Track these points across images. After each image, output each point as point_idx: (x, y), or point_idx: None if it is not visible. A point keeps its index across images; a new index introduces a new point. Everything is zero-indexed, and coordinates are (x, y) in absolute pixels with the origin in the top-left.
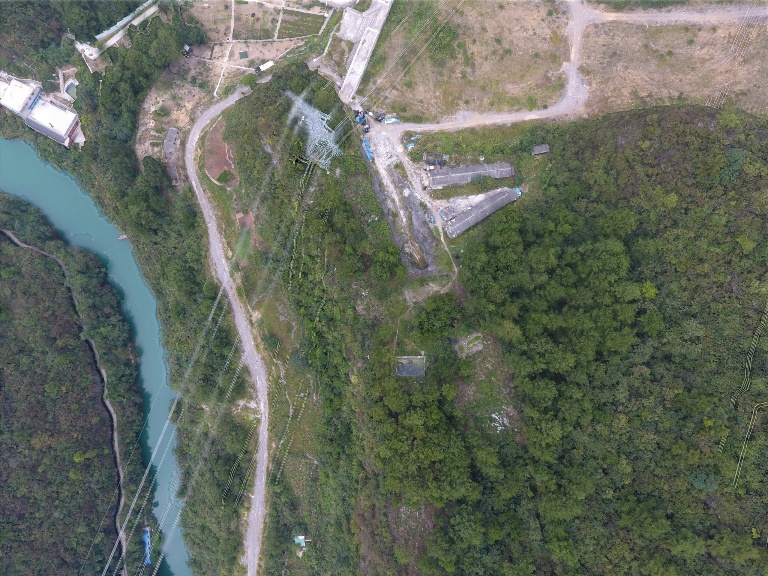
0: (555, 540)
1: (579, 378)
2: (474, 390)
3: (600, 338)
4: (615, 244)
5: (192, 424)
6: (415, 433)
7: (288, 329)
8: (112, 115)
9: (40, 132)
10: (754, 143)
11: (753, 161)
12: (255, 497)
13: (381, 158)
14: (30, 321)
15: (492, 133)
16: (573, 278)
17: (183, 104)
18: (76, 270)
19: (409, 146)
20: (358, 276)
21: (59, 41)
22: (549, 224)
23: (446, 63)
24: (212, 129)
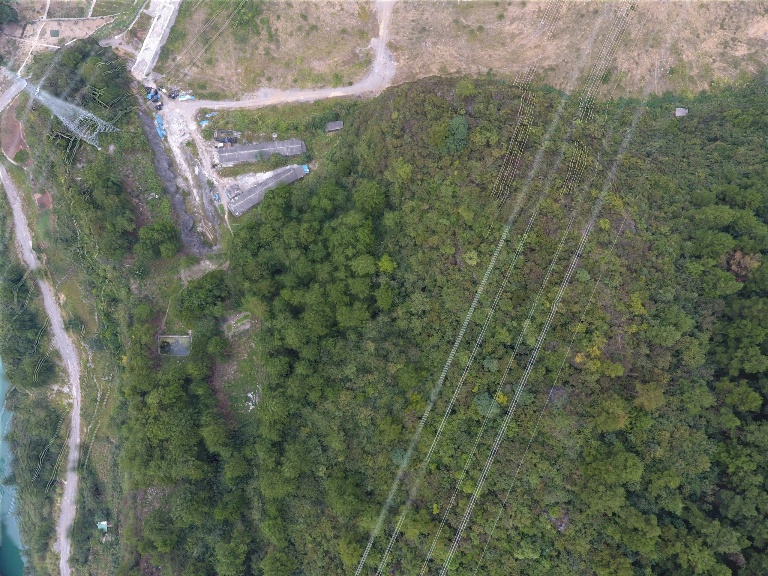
0: (267, 519)
1: (311, 354)
2: (234, 369)
3: (331, 313)
4: (354, 217)
5: (15, 410)
6: (150, 412)
7: (91, 311)
8: None
9: None
10: (492, 112)
11: (484, 130)
12: (68, 483)
13: (174, 136)
14: None
15: (292, 110)
16: (321, 253)
17: None
18: None
19: (203, 123)
20: (122, 254)
21: None
22: (312, 199)
23: (249, 39)
24: (9, 108)
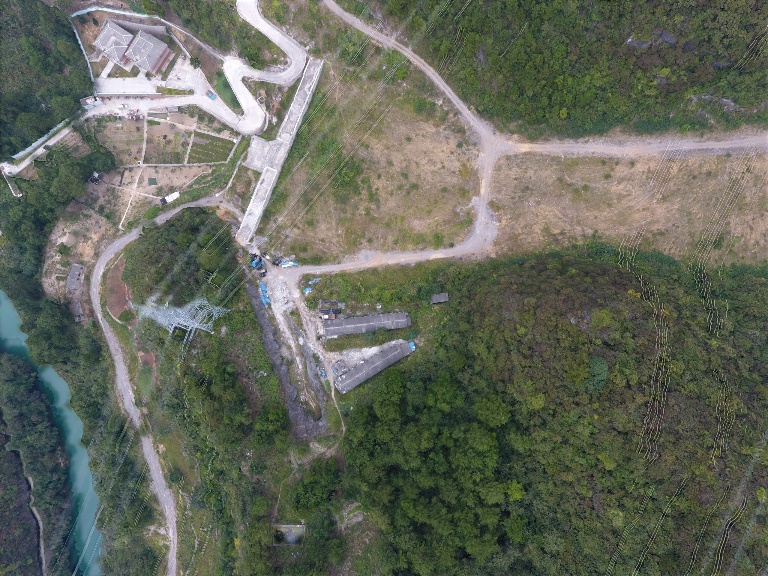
0: None
1: None
2: (349, 566)
3: (460, 543)
4: (482, 441)
5: (110, 540)
6: None
7: (191, 465)
8: (19, 248)
9: None
10: (629, 342)
11: (623, 367)
12: None
13: (278, 303)
14: None
15: (394, 275)
16: (444, 467)
17: (89, 236)
18: (3, 380)
19: (306, 291)
20: (237, 444)
21: None
22: (429, 399)
23: (349, 200)
24: (113, 267)
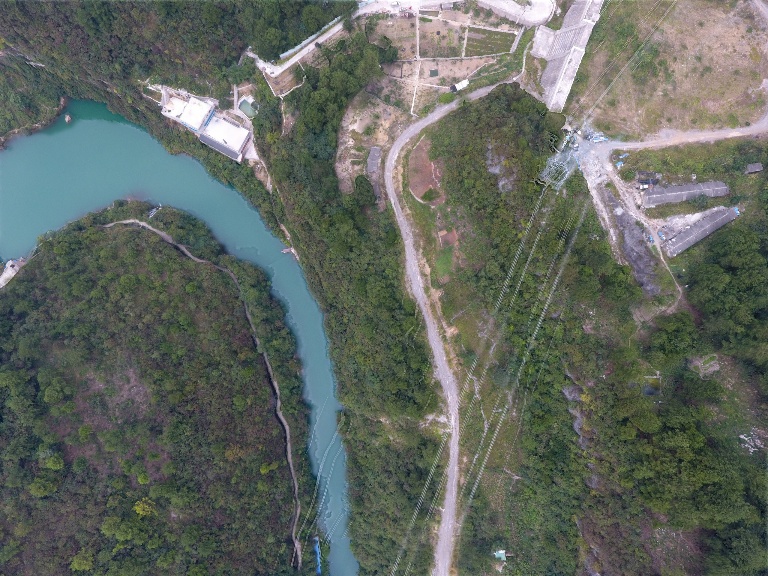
0: None
1: None
2: (717, 411)
3: None
4: None
5: (372, 437)
6: (681, 455)
7: (487, 345)
8: (313, 134)
9: (213, 148)
10: None
11: None
12: (445, 510)
13: (591, 177)
14: (214, 335)
15: (698, 151)
16: None
17: (380, 123)
18: (249, 284)
19: (618, 165)
20: (595, 296)
21: (238, 59)
22: None
23: (648, 81)
24: (416, 148)
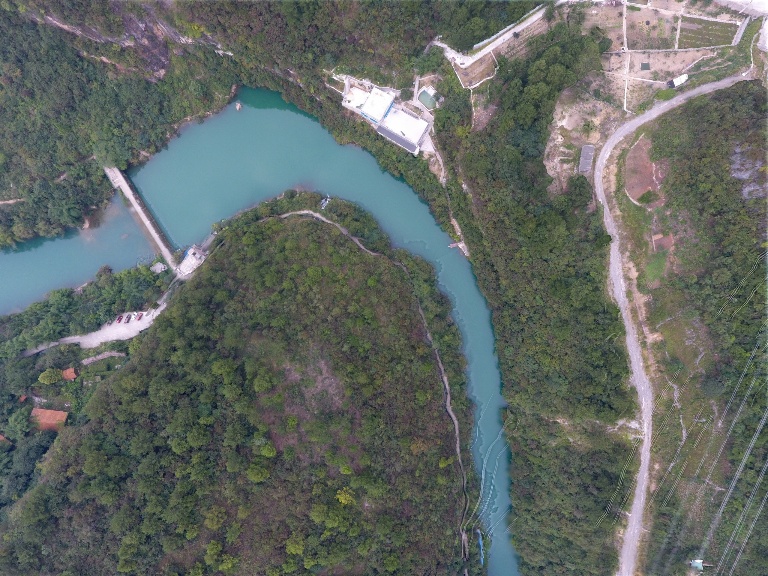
0: None
1: None
2: None
3: None
4: None
5: (551, 437)
6: None
7: (695, 354)
8: (521, 130)
9: (390, 140)
10: None
11: None
12: (632, 515)
13: None
14: (394, 329)
15: None
16: None
17: (590, 119)
18: (423, 279)
19: None
20: None
21: (424, 49)
22: None
23: None
24: (634, 147)
